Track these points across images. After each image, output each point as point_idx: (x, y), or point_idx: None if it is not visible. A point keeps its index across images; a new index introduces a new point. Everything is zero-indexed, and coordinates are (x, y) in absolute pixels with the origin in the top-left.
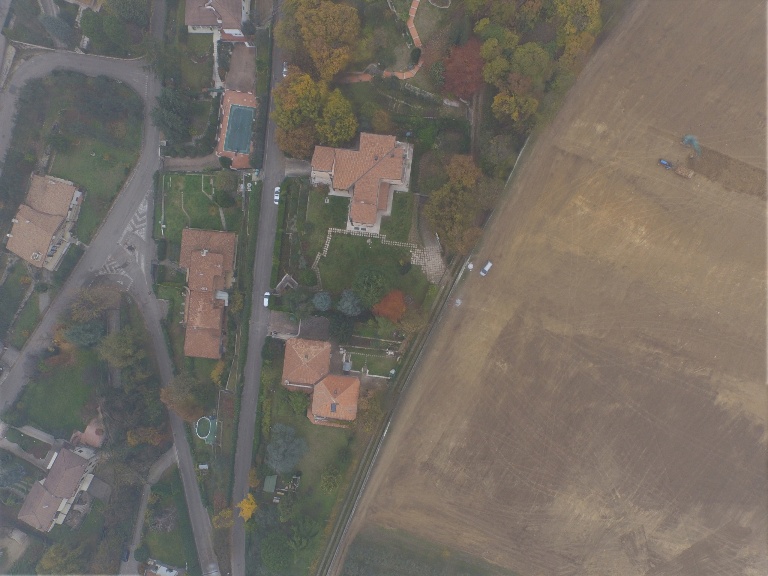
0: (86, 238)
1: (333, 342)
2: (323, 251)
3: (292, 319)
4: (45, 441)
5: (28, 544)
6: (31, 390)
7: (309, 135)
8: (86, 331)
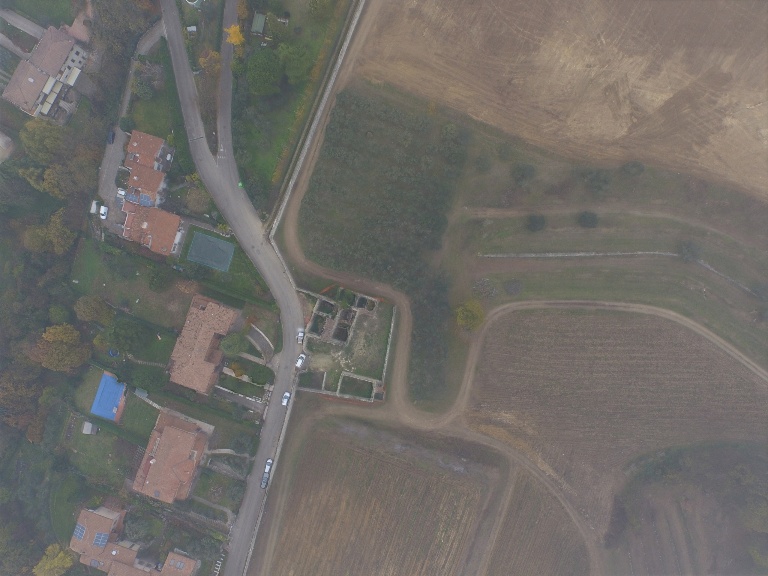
0: None
1: None
2: None
3: None
4: (32, 34)
5: (12, 149)
6: None
7: None
8: None
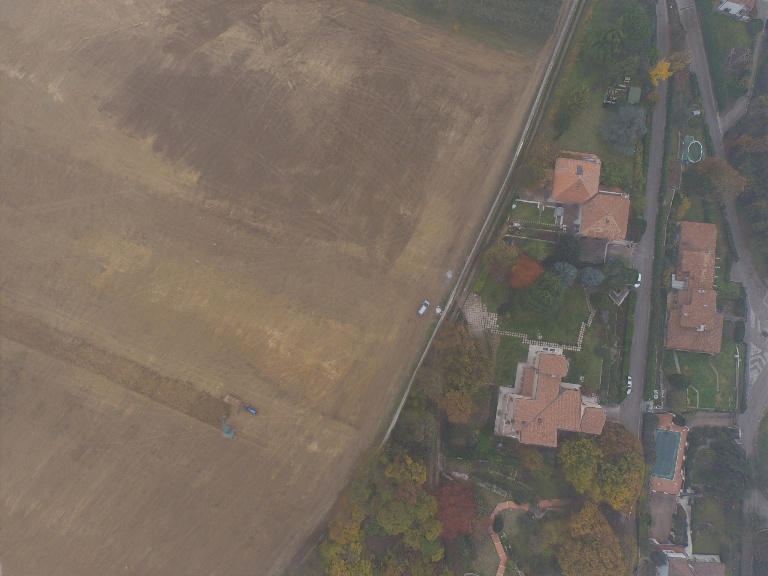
0: None
1: None
2: (585, 328)
3: None
4: None
5: None
6: None
7: (606, 446)
8: None
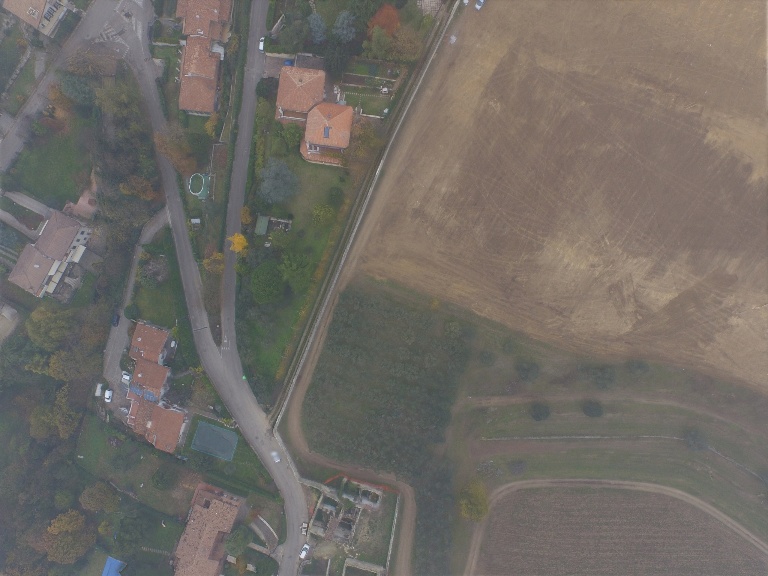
0: (83, 4)
1: (328, 83)
2: None
3: (287, 63)
4: (38, 212)
5: (18, 321)
6: (25, 158)
7: None
8: (81, 82)
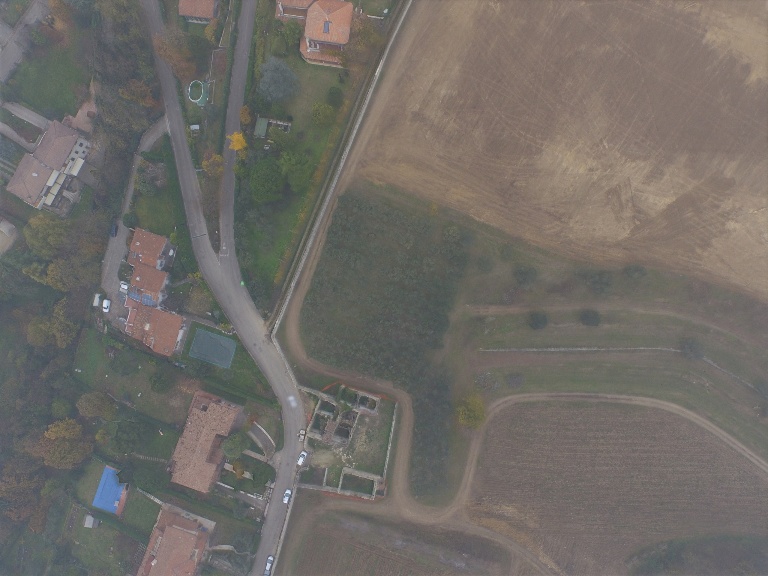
0: None
1: None
2: None
3: None
4: (36, 125)
5: (16, 236)
6: (23, 70)
7: None
8: None
